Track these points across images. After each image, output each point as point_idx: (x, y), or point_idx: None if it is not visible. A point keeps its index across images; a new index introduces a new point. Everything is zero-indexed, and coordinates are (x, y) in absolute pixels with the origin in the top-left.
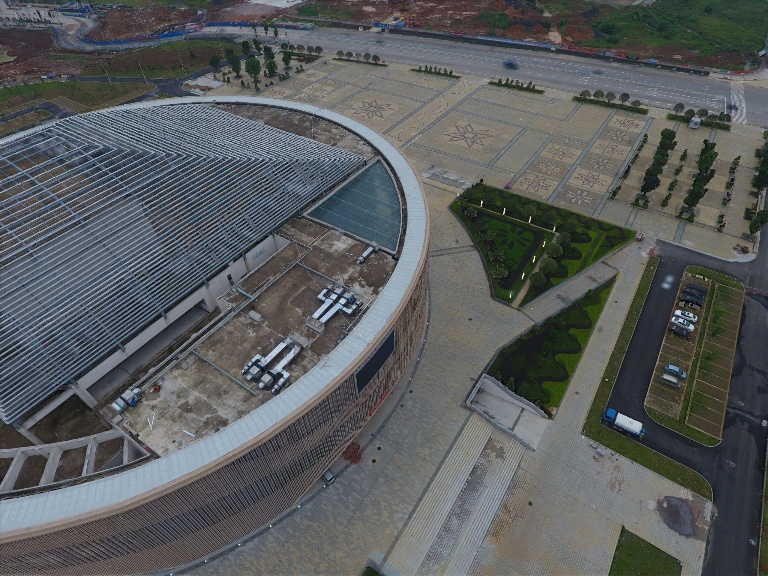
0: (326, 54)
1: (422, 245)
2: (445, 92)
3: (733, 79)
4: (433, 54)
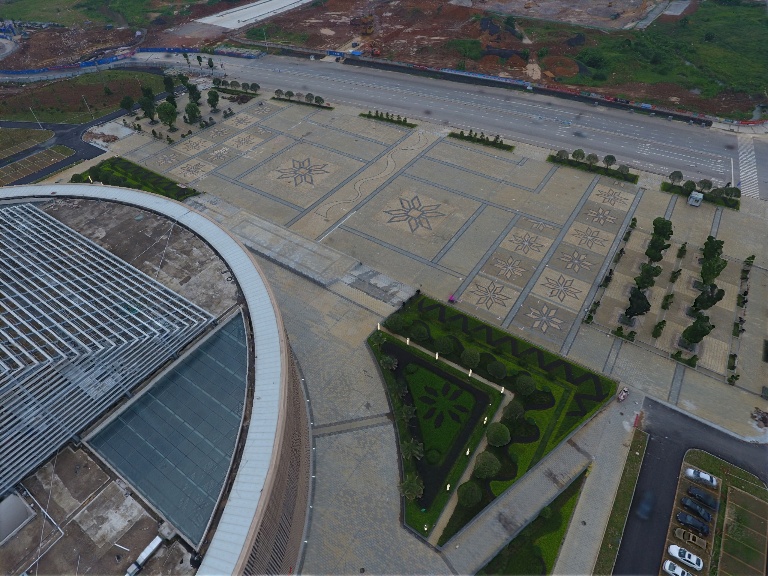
0: (265, 91)
1: (246, 532)
2: (395, 147)
3: (740, 131)
4: (389, 93)
